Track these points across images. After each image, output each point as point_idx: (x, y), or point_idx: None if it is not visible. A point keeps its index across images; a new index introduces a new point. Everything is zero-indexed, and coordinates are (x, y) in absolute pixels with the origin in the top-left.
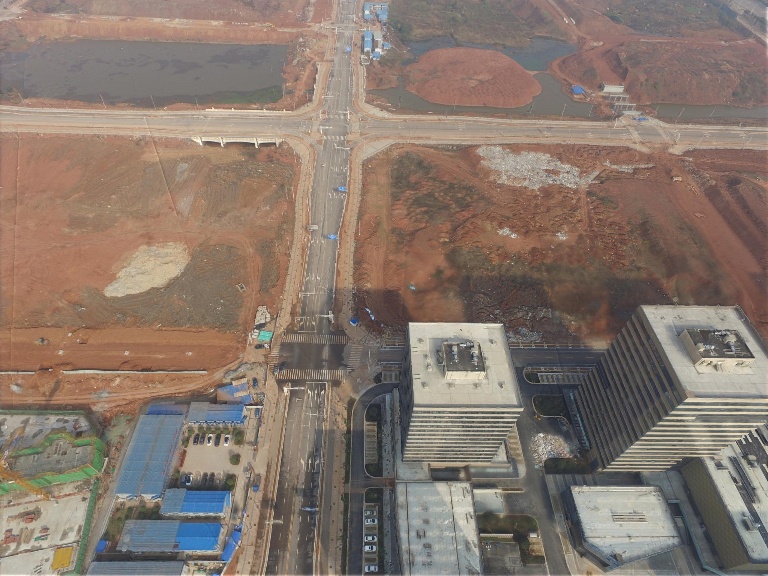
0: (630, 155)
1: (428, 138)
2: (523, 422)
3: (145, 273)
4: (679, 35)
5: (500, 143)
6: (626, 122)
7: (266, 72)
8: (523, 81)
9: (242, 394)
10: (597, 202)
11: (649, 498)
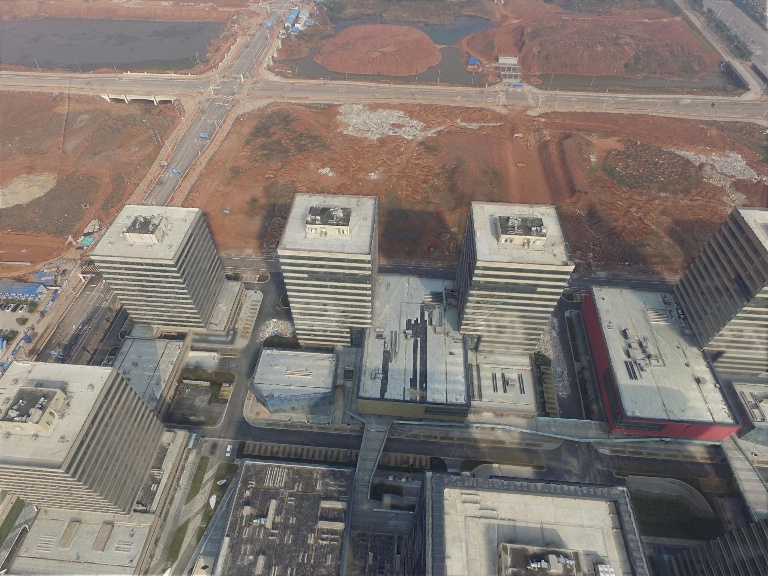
0: (483, 114)
1: (306, 98)
2: (265, 310)
3: (15, 193)
4: (607, 14)
5: (369, 103)
6: (500, 88)
7: (195, 45)
8: (423, 53)
9: (47, 278)
10: (422, 150)
11: (324, 362)
